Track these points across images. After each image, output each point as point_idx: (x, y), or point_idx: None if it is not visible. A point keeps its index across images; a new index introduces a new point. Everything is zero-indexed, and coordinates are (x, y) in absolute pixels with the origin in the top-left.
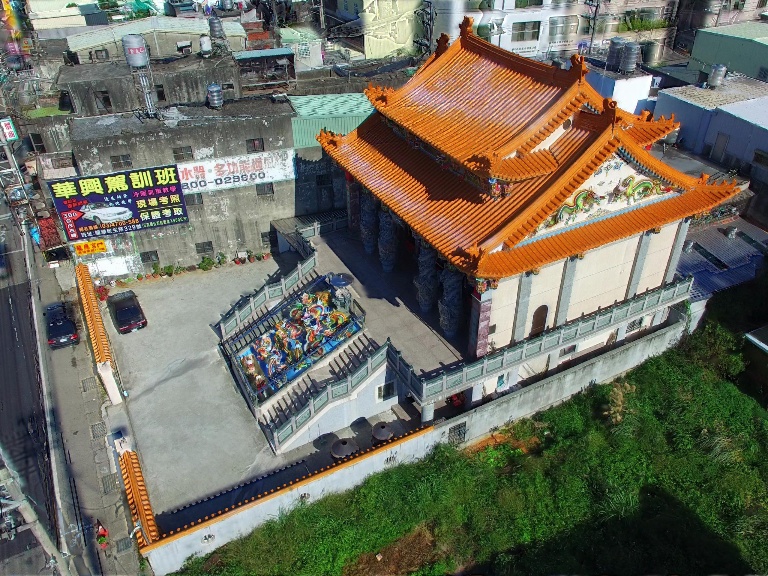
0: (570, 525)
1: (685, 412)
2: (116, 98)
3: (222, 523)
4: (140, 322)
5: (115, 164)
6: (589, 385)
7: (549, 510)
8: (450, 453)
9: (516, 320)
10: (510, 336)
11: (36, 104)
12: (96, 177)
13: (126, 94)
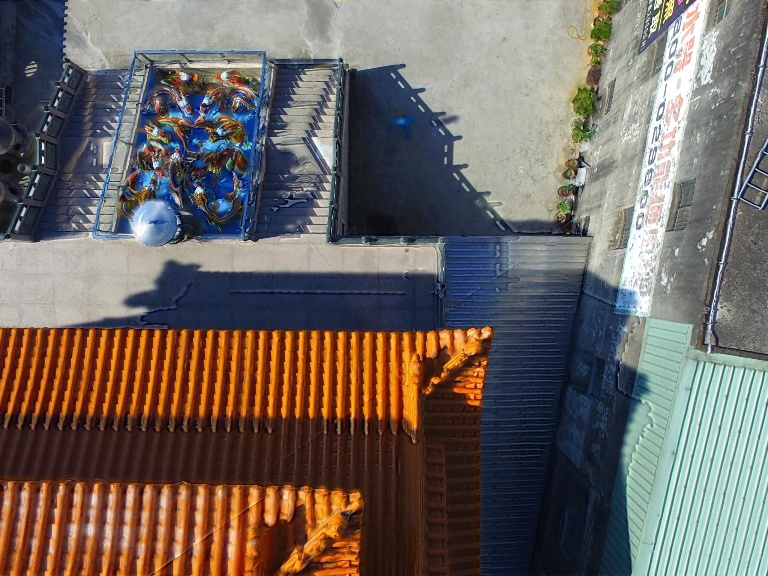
0: None
1: None
2: None
3: None
4: None
5: None
6: None
7: None
8: None
9: None
10: None
11: None
12: None
13: None
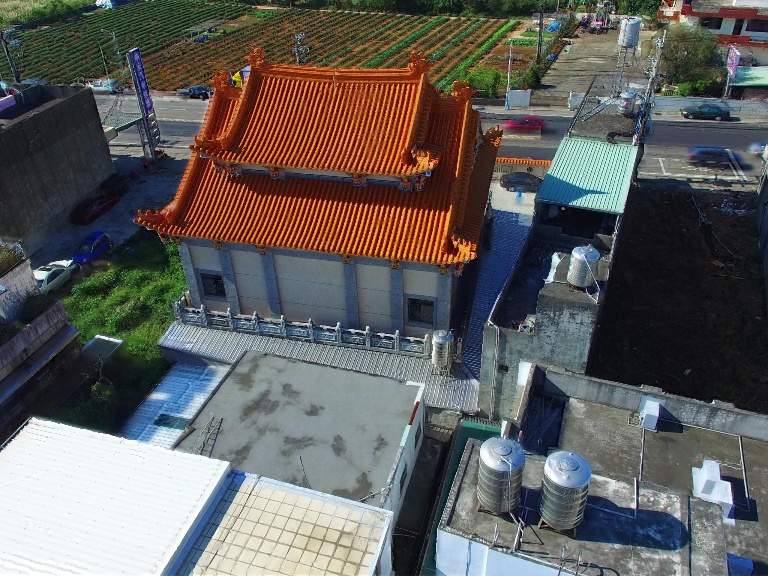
0: None
1: None
2: None
3: None
4: None
5: None
6: None
7: None
8: None
9: None
10: None
11: None
12: None
13: None
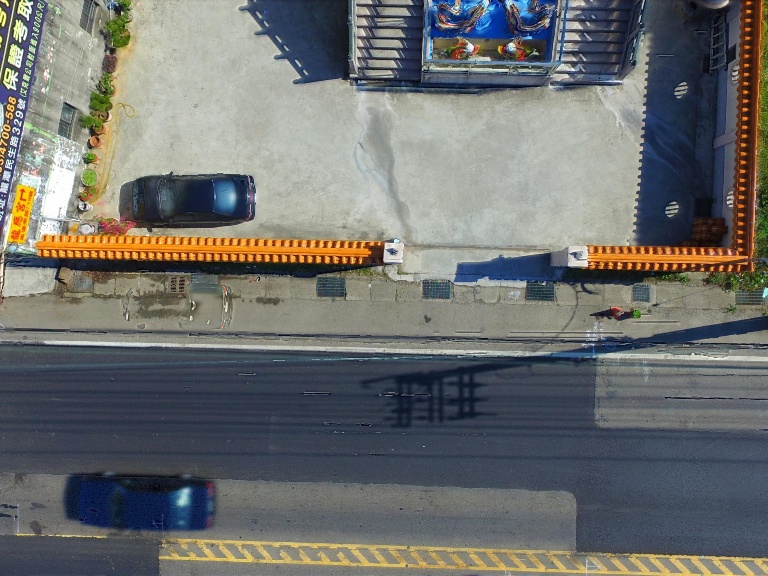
0: None
1: None
2: None
3: None
4: (249, 184)
5: None
6: None
7: None
8: None
9: None
10: None
11: None
12: None
13: None
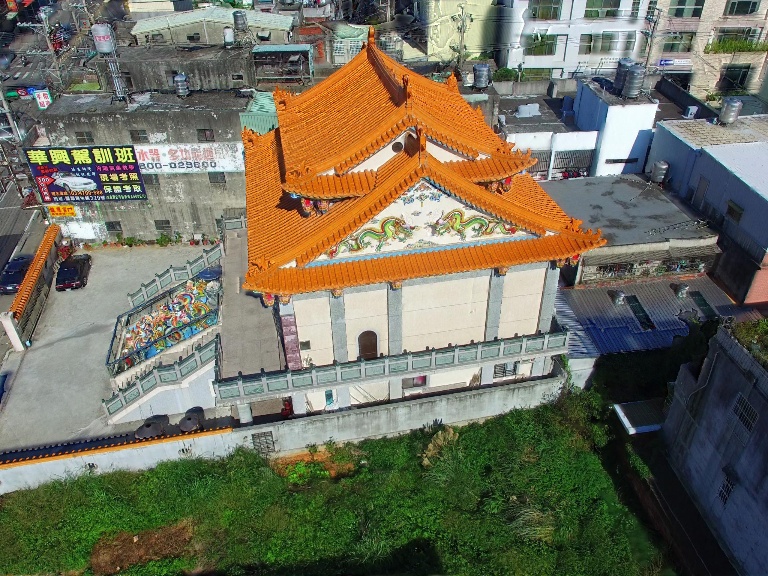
0: (316, 557)
1: (512, 474)
2: (137, 79)
3: (6, 471)
4: (74, 283)
5: (80, 139)
6: (434, 423)
7: (307, 537)
8: (246, 458)
9: (333, 340)
10: (332, 356)
11: (83, 79)
12: (64, 149)
13: (145, 77)
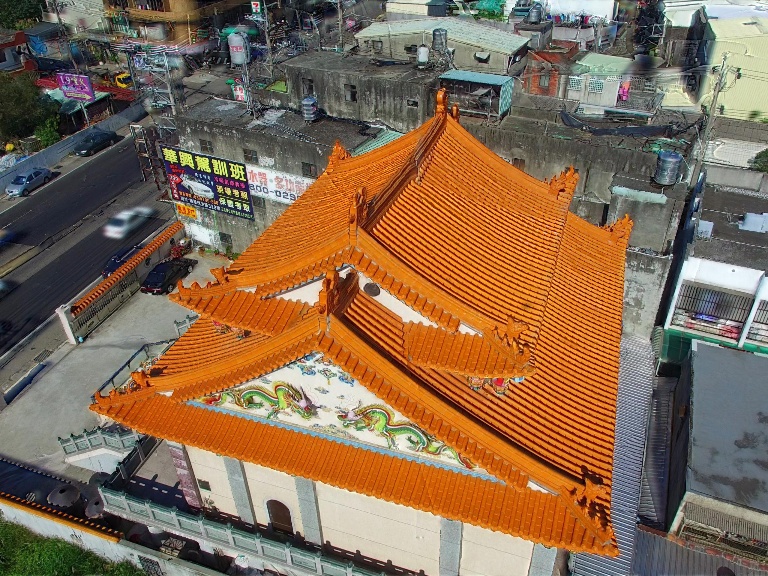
0: None
1: None
2: (318, 88)
3: None
4: (155, 289)
5: (204, 147)
6: None
7: None
8: None
9: None
10: None
11: None
12: (190, 153)
13: (326, 87)
